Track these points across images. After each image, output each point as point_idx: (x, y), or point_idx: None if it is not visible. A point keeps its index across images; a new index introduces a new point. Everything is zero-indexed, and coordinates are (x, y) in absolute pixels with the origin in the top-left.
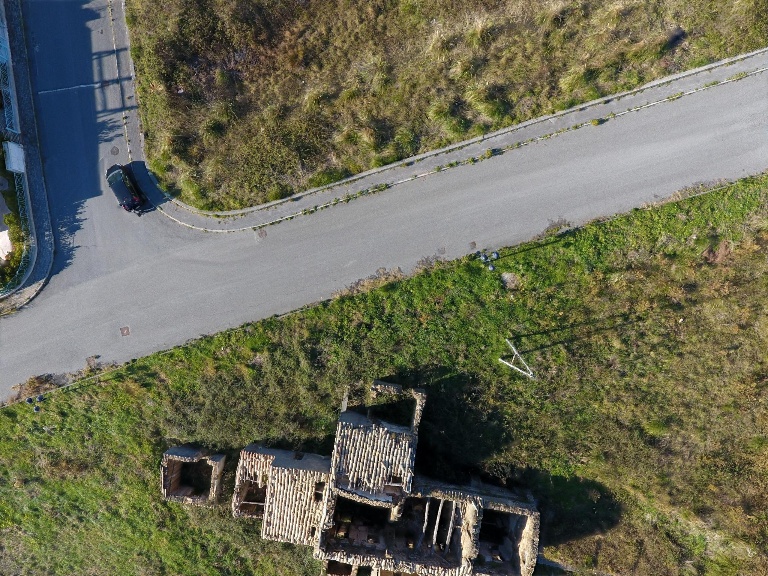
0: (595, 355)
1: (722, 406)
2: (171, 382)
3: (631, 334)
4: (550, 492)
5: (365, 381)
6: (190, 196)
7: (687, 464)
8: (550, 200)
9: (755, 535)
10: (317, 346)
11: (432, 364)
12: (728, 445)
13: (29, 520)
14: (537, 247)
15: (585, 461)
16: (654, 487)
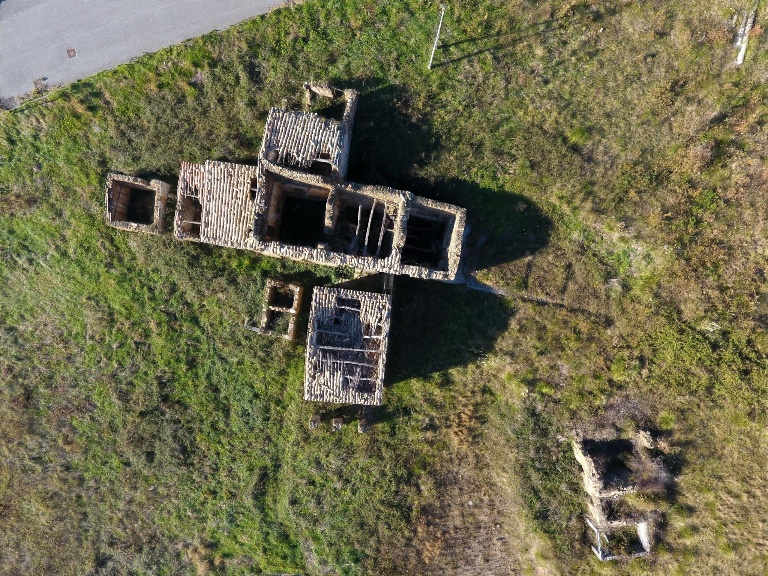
0: (520, 63)
1: (641, 115)
2: (116, 104)
3: (554, 41)
4: (481, 212)
5: (301, 94)
6: None
7: (609, 173)
8: None
9: (674, 240)
10: (256, 60)
11: (365, 74)
12: (648, 154)
13: None
14: None
15: (512, 171)
16: (578, 196)
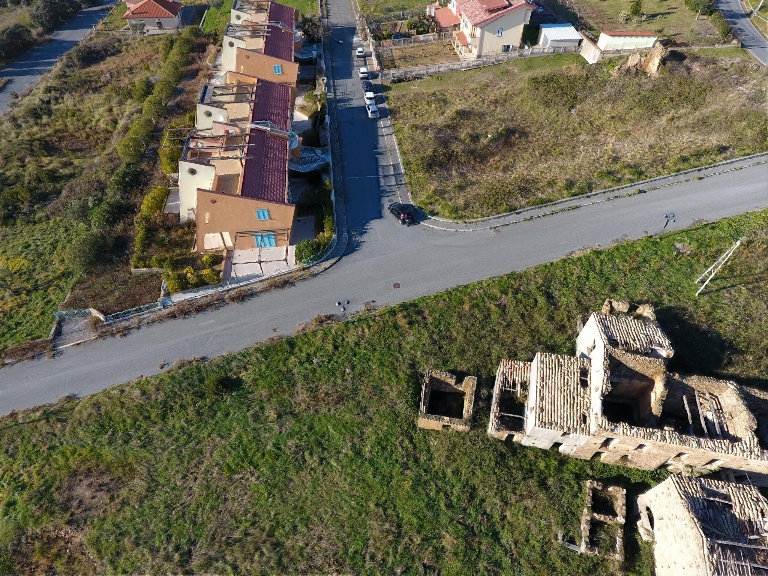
0: None
1: None
2: (431, 319)
3: None
4: None
5: None
6: (445, 214)
7: None
8: (688, 210)
9: None
10: (549, 290)
11: None
12: None
13: (267, 462)
14: (692, 230)
15: None
16: None
